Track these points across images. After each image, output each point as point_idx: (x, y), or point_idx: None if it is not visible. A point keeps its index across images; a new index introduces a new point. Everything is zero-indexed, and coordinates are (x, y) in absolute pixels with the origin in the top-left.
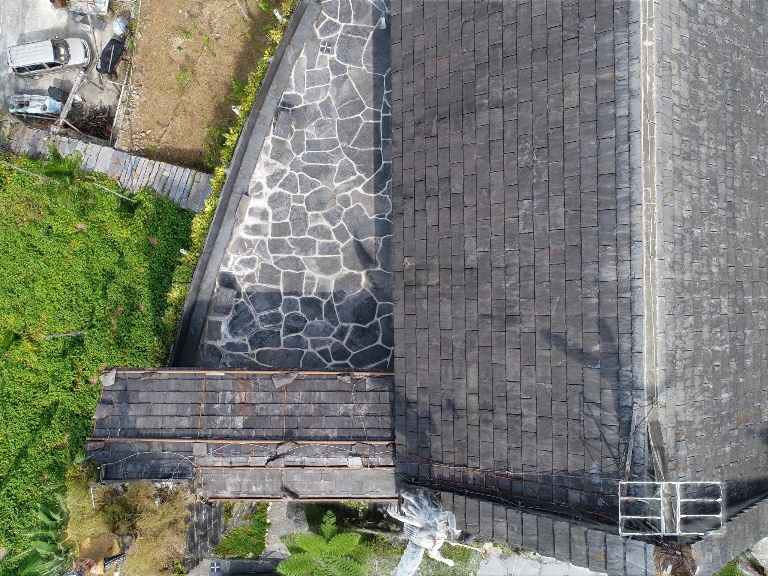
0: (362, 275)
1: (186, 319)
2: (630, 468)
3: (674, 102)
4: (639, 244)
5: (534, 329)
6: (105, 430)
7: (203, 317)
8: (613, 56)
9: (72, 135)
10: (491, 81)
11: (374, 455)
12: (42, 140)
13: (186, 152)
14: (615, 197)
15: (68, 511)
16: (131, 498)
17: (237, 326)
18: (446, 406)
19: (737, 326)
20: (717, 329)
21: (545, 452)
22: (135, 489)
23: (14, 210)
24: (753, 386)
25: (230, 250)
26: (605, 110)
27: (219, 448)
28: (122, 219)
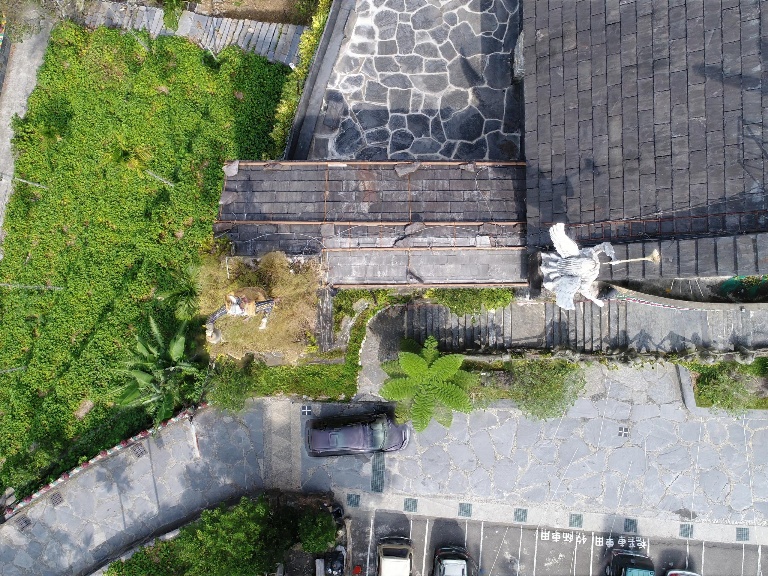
0: (469, 92)
1: (296, 132)
2: None
3: None
4: None
5: (685, 67)
6: (231, 215)
7: (312, 132)
8: None
9: (148, 6)
10: None
11: (502, 235)
12: (118, 12)
13: (268, 13)
14: None
15: (164, 346)
16: (266, 267)
17: (344, 143)
18: (585, 166)
19: None
20: None
21: (699, 185)
22: (270, 258)
23: (93, 77)
24: None
25: (337, 68)
26: None
27: (347, 230)
28: (209, 72)
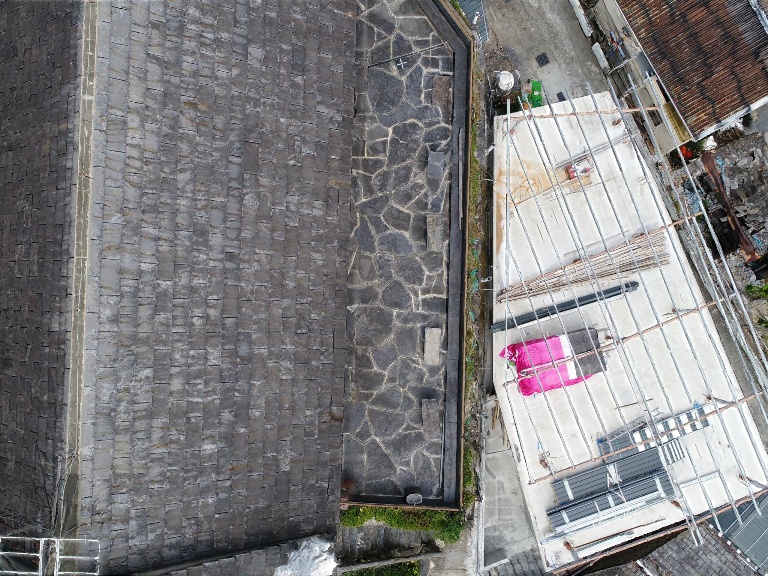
0: None
1: None
2: (55, 520)
3: (131, 155)
4: (71, 297)
5: None
6: None
7: None
8: (67, 108)
9: None
10: (8, 124)
11: None
12: None
13: None
14: (61, 248)
15: None
16: None
17: None
18: None
19: (238, 377)
20: (198, 380)
21: (17, 497)
22: None
23: None
24: (265, 436)
25: None
26: (61, 161)
27: None
28: None
